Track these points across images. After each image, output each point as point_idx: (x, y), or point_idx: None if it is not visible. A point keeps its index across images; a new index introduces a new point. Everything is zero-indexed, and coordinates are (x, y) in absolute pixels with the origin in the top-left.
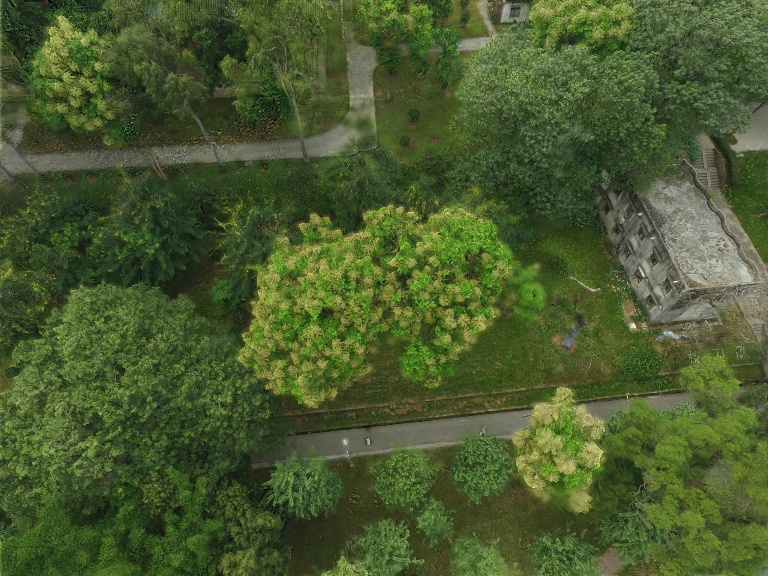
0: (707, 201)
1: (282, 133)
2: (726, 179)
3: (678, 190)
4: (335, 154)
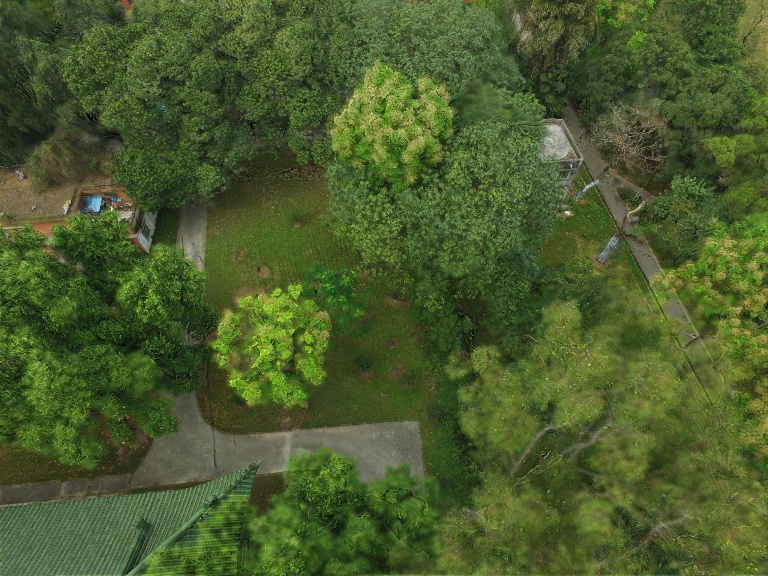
0: None
1: None
2: None
3: None
4: (421, 486)
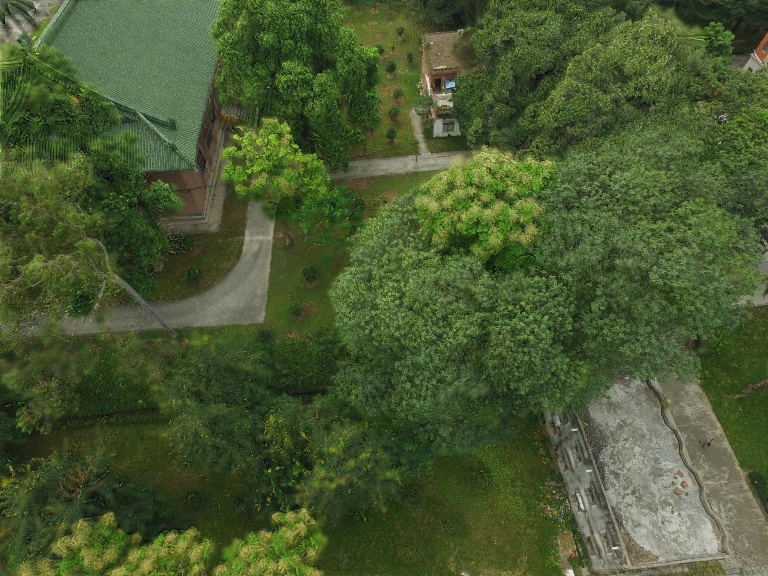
0: (661, 410)
1: (153, 292)
2: (693, 346)
3: (625, 391)
4: (212, 323)
